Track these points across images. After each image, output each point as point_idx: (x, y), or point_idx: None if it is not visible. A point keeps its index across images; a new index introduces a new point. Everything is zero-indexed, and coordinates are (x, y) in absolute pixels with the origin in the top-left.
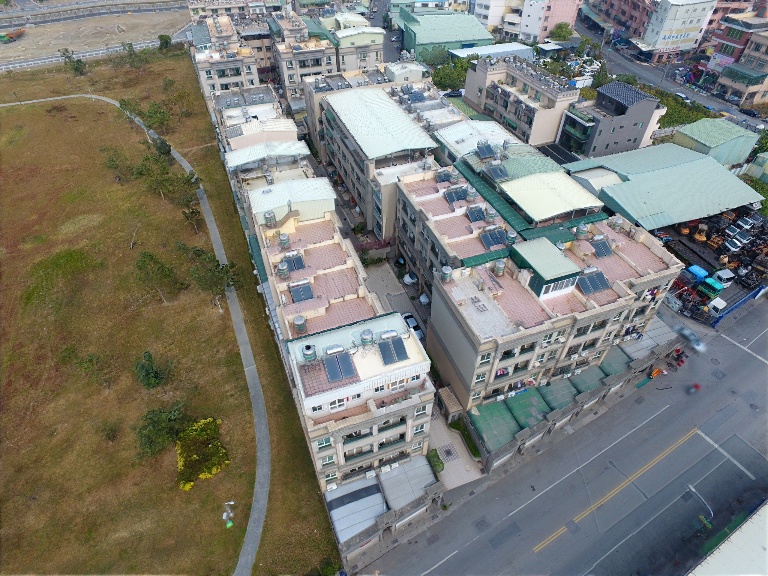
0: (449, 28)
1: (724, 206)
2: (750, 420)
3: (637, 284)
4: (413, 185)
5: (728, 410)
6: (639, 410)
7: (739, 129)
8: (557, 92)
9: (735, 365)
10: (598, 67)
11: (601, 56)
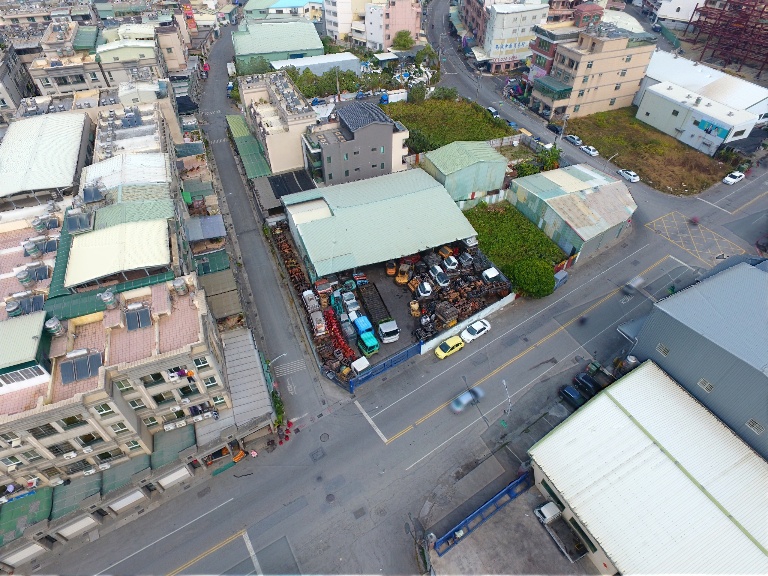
0: (280, 37)
1: (425, 244)
2: (314, 516)
3: (120, 371)
4: (10, 235)
5: (297, 503)
6: (194, 506)
7: (487, 153)
8: (286, 115)
9: (344, 442)
10: (427, 78)
11: (436, 66)
